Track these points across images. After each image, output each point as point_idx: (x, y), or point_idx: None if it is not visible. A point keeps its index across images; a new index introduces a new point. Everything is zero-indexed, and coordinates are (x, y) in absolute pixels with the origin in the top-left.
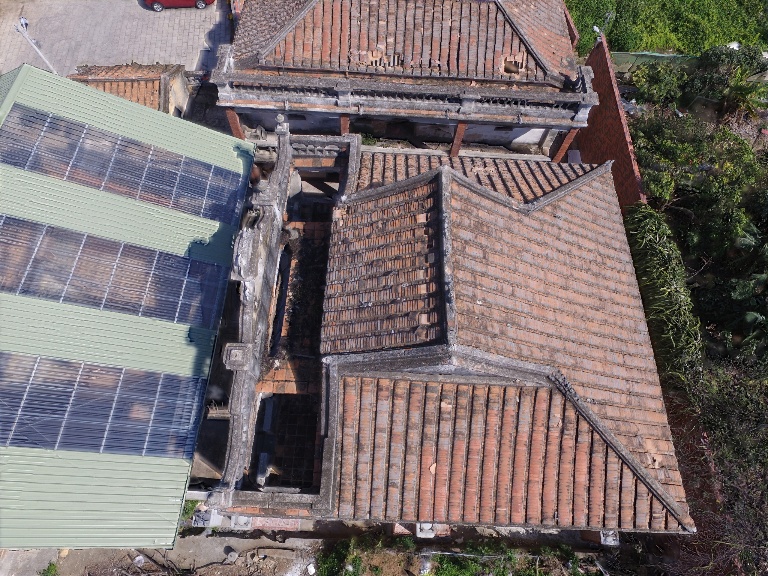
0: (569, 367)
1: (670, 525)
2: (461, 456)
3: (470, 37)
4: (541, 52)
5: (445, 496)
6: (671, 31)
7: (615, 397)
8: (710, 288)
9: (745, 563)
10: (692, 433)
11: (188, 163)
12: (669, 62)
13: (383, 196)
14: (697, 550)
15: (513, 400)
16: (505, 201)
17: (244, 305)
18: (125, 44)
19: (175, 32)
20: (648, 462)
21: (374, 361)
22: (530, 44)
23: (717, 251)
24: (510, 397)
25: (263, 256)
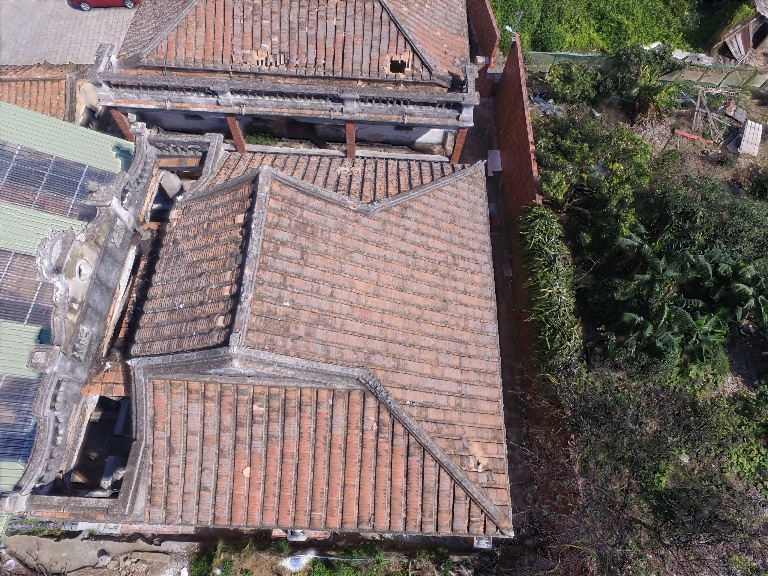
0: (389, 369)
1: (488, 529)
2: (275, 459)
3: (355, 36)
4: (429, 51)
5: (259, 500)
6: (596, 31)
7: (441, 399)
8: (598, 289)
9: (609, 566)
10: (558, 435)
11: (58, 163)
12: (588, 62)
13: (215, 196)
14: (549, 554)
15: (326, 403)
16: (340, 201)
17: (56, 307)
18: (50, 43)
19: (102, 31)
20: (470, 465)
21: (172, 363)
22: (415, 43)
23: (609, 252)
24: (322, 400)
25: (92, 257)
